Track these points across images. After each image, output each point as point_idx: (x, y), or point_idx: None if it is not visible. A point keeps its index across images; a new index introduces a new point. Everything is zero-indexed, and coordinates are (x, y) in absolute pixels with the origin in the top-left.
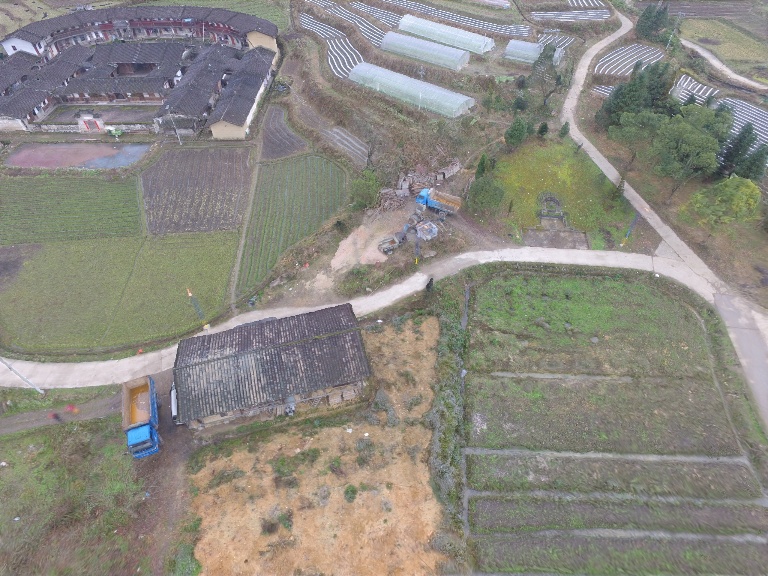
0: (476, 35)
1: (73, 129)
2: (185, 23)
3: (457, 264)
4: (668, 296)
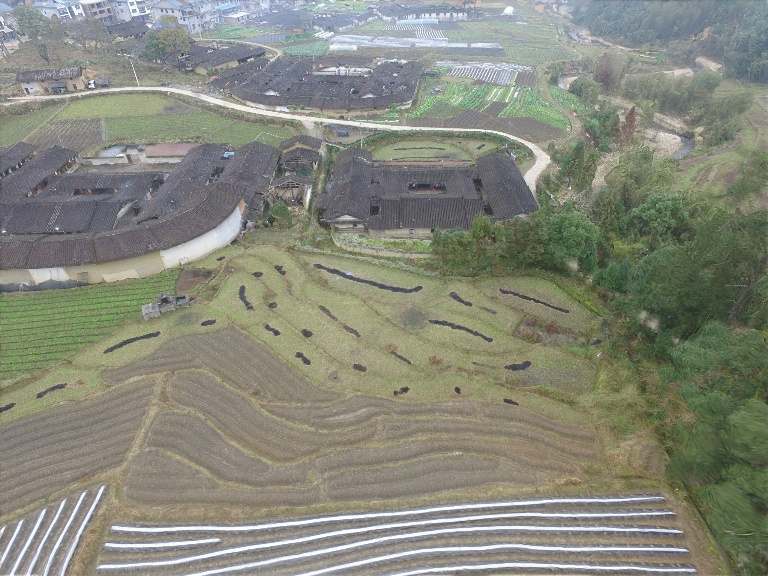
0: None
1: None
2: None
3: None
4: None
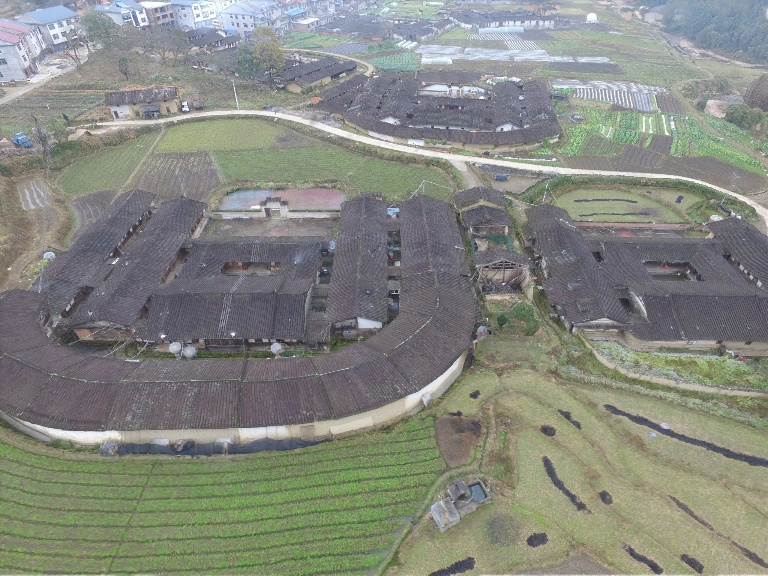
0: None
1: (298, 215)
2: None
3: None
4: None
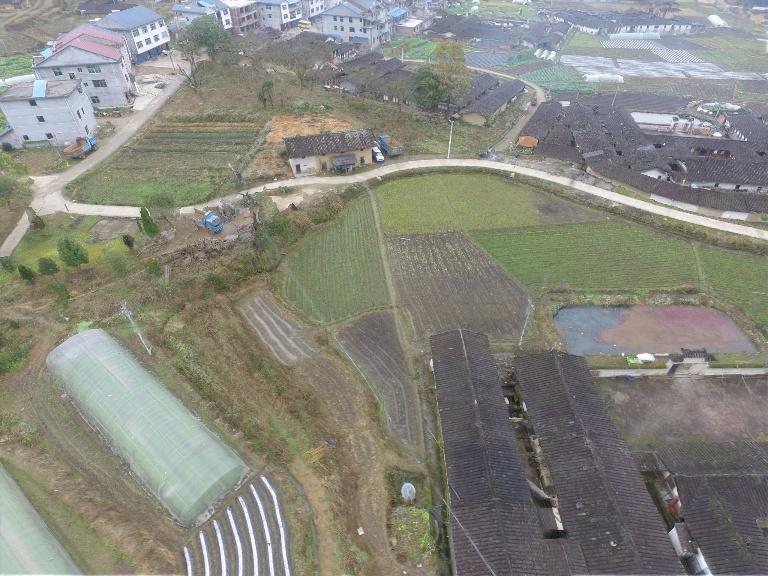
0: None
1: None
2: None
3: (211, 204)
4: (81, 196)
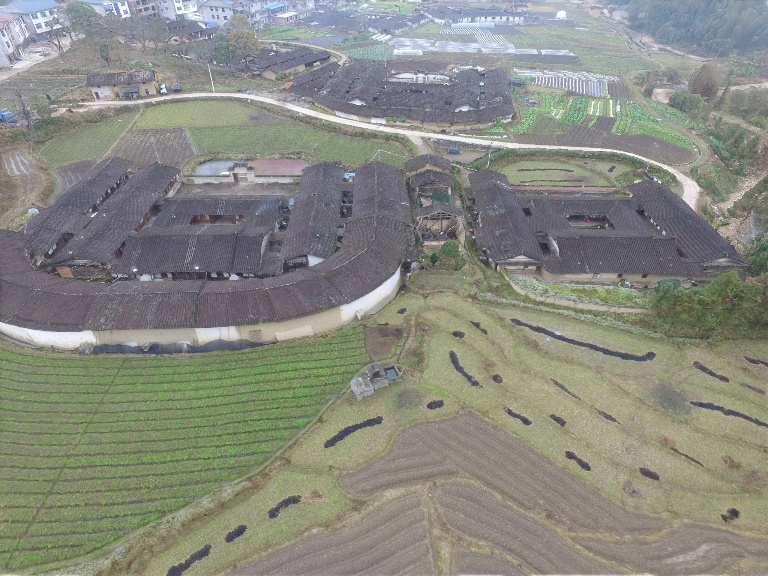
0: None
1: (264, 180)
2: None
3: None
4: None
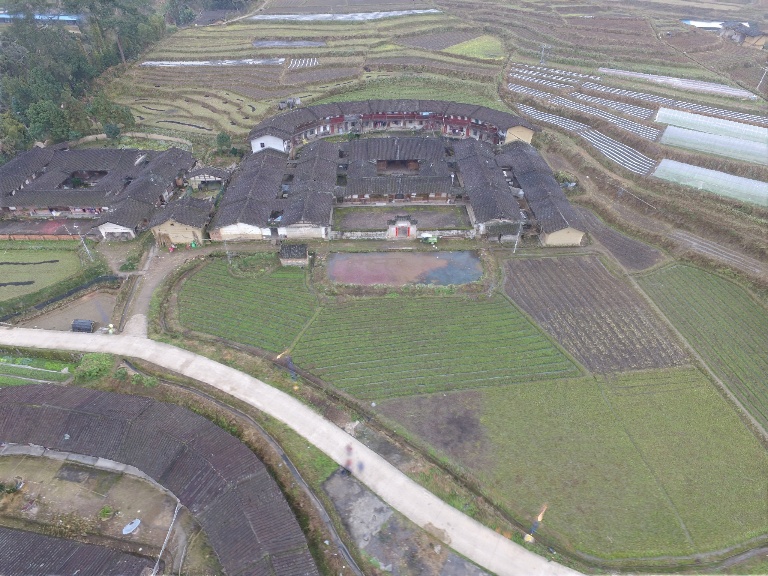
0: (767, 129)
1: (378, 236)
2: (419, 116)
3: None
4: None
